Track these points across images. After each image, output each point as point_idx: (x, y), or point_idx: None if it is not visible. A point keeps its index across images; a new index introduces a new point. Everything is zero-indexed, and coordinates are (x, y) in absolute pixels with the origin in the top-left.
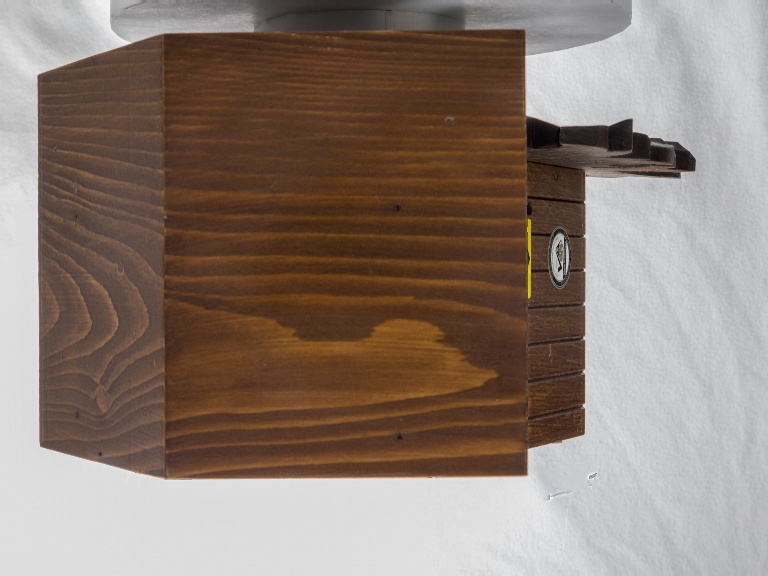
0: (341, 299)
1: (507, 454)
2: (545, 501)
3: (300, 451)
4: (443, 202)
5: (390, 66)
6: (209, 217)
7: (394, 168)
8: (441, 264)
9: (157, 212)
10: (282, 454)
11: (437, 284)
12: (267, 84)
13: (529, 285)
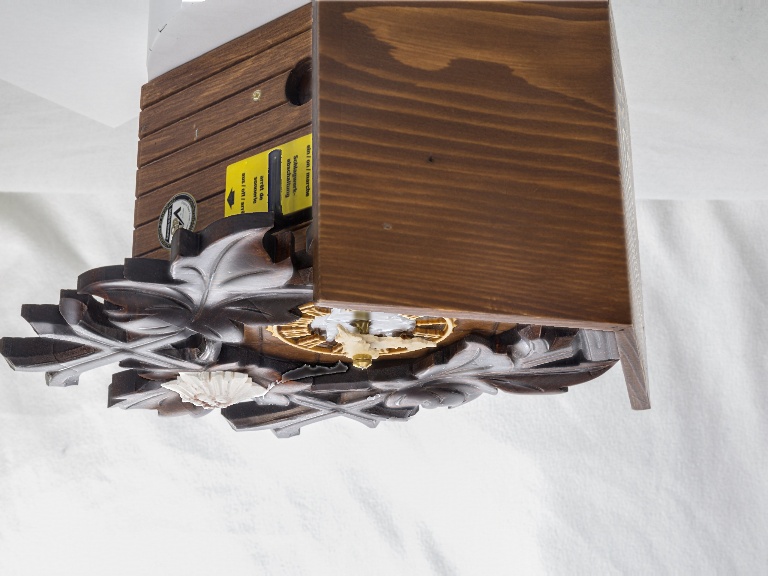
0: (476, 92)
1: None
2: None
3: None
4: (392, 159)
5: (441, 279)
6: (586, 171)
7: (435, 192)
8: (393, 109)
9: None
10: None
11: (396, 93)
12: (545, 274)
13: (229, 177)
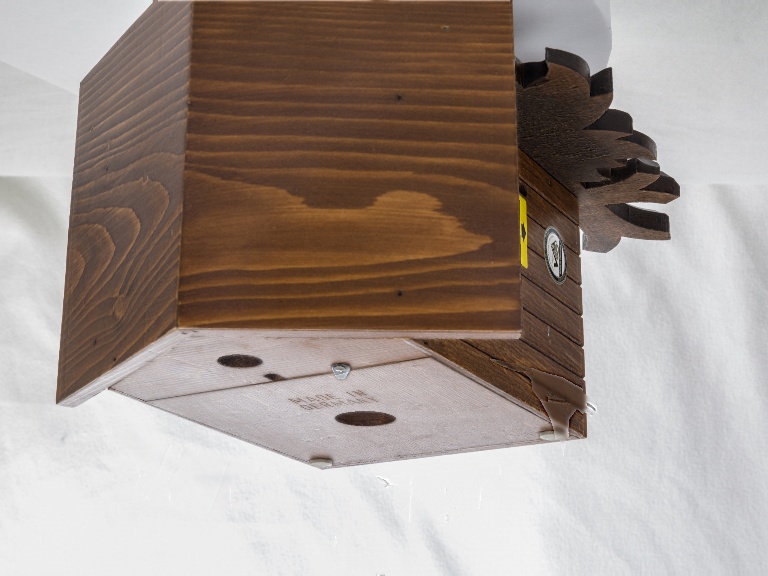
0: (346, 173)
1: (502, 311)
2: (543, 400)
3: (305, 305)
4: (440, 94)
5: None
6: (228, 103)
7: (396, 65)
8: (438, 145)
9: (182, 103)
10: (288, 307)
11: (435, 161)
12: None
13: (526, 257)
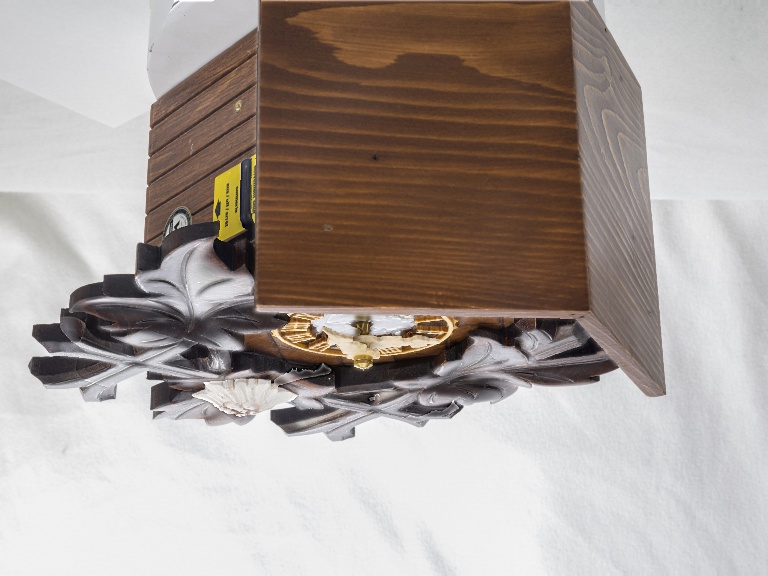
0: (424, 86)
1: None
2: None
3: None
4: (334, 160)
5: (384, 277)
6: (541, 157)
7: (379, 190)
8: (336, 110)
9: None
10: None
11: (340, 94)
12: (495, 265)
13: (216, 188)
